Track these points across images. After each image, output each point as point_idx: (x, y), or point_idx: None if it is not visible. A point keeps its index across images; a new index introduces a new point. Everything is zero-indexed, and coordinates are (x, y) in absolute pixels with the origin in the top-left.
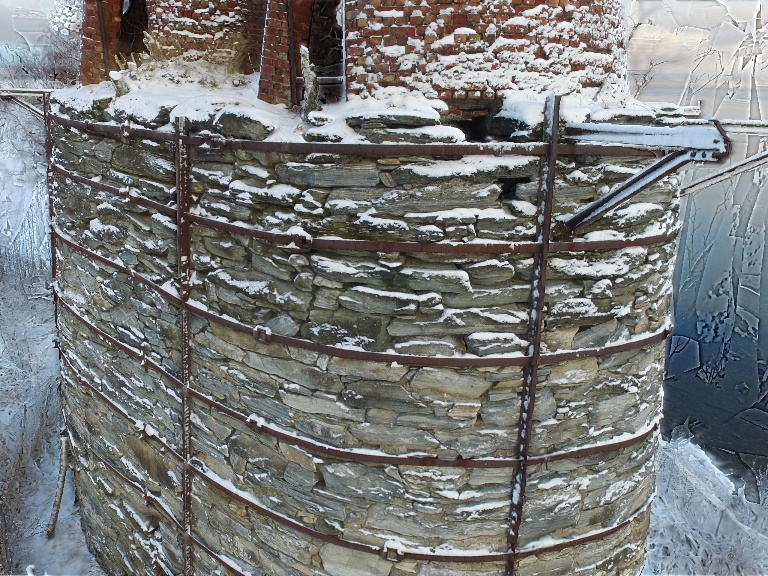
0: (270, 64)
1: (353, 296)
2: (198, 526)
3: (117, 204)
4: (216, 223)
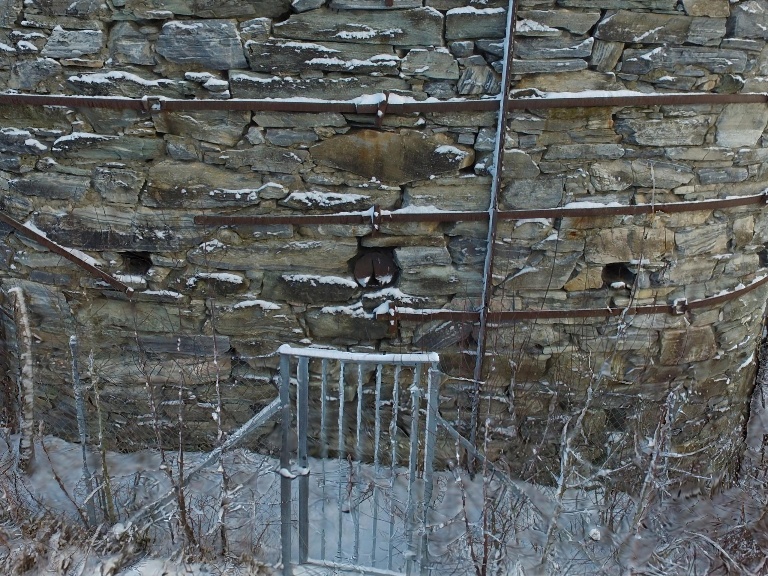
0: None
1: None
2: (509, 196)
3: None
4: None
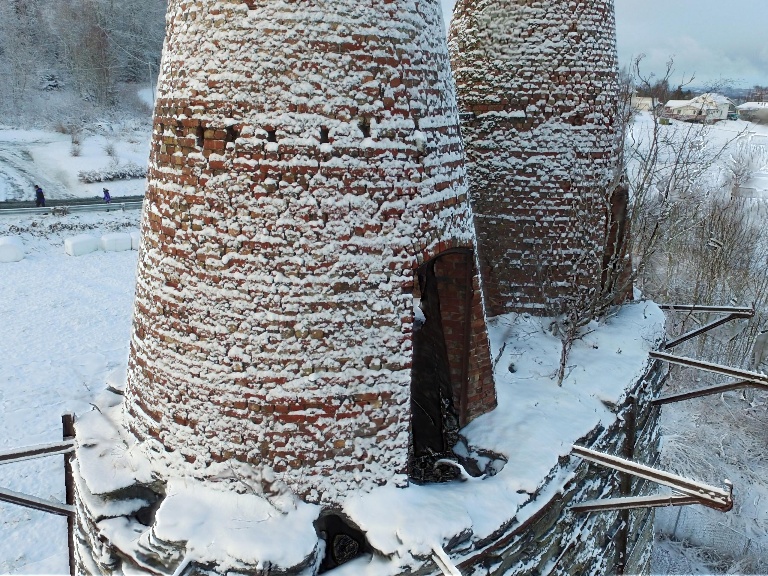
0: None
1: None
2: None
3: None
4: None
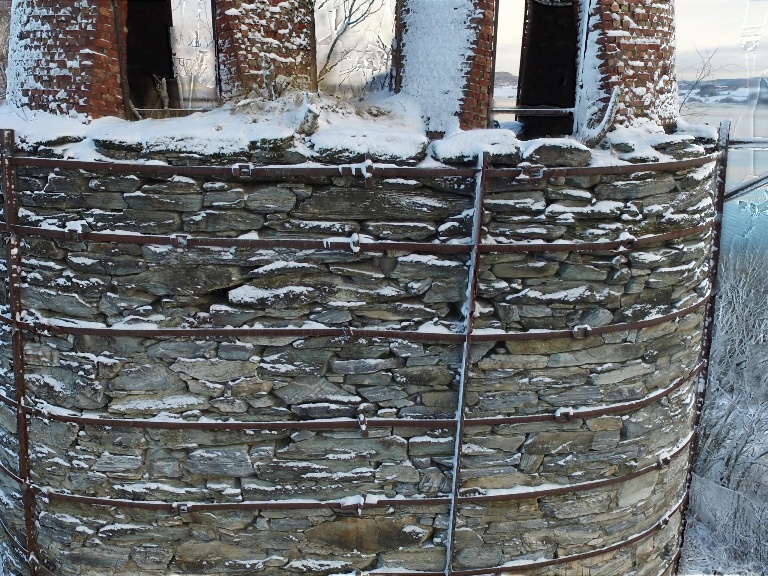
0: (473, 97)
1: (656, 277)
2: (461, 558)
3: (310, 259)
4: (531, 246)
